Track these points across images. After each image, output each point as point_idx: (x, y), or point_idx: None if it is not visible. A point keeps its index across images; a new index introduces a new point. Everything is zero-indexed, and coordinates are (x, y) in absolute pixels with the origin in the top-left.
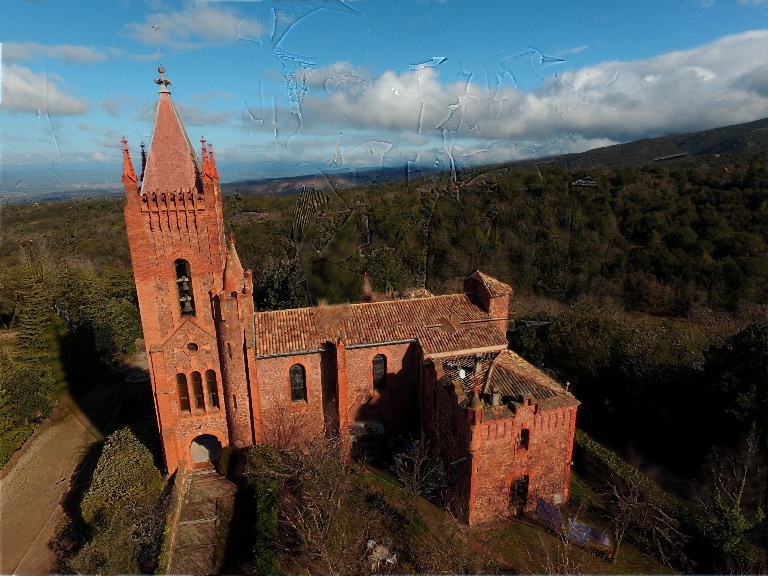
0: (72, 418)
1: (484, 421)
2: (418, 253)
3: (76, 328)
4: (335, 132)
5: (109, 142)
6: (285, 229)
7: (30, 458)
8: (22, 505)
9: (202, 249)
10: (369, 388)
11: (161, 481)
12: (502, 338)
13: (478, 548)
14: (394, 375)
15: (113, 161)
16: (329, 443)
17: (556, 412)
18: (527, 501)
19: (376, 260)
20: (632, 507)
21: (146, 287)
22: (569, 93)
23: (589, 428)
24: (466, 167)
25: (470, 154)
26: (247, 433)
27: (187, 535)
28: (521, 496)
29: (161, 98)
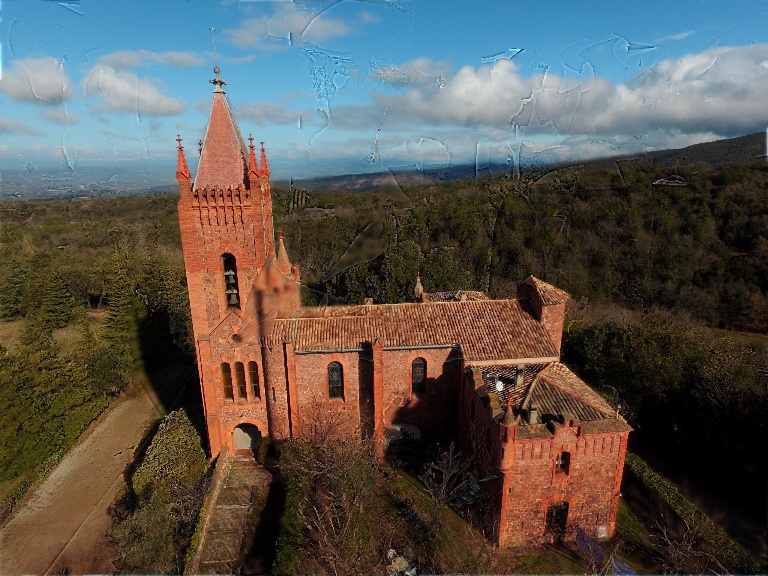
0: (144, 394)
1: (518, 439)
2: (484, 253)
3: (153, 312)
4: (372, 129)
5: (193, 140)
6: (351, 225)
7: (105, 428)
8: (92, 470)
9: (247, 244)
10: (407, 391)
11: (205, 463)
12: (553, 350)
13: (505, 574)
14: (434, 380)
15: (195, 158)
16: (360, 444)
17: (603, 437)
18: (566, 530)
19: (434, 259)
20: (684, 555)
21: (196, 279)
22: (660, 83)
23: (652, 455)
24: (535, 164)
25: (541, 151)
26: (285, 426)
27: (221, 519)
28: (560, 523)
29: (216, 98)
